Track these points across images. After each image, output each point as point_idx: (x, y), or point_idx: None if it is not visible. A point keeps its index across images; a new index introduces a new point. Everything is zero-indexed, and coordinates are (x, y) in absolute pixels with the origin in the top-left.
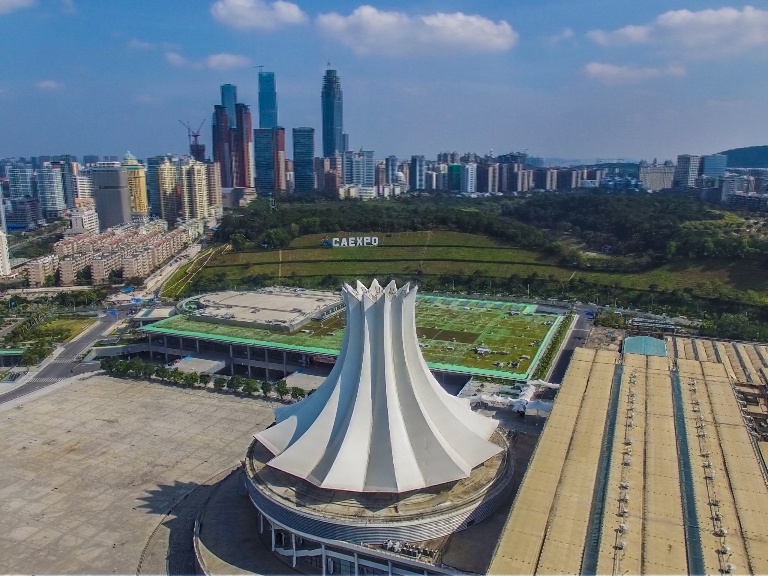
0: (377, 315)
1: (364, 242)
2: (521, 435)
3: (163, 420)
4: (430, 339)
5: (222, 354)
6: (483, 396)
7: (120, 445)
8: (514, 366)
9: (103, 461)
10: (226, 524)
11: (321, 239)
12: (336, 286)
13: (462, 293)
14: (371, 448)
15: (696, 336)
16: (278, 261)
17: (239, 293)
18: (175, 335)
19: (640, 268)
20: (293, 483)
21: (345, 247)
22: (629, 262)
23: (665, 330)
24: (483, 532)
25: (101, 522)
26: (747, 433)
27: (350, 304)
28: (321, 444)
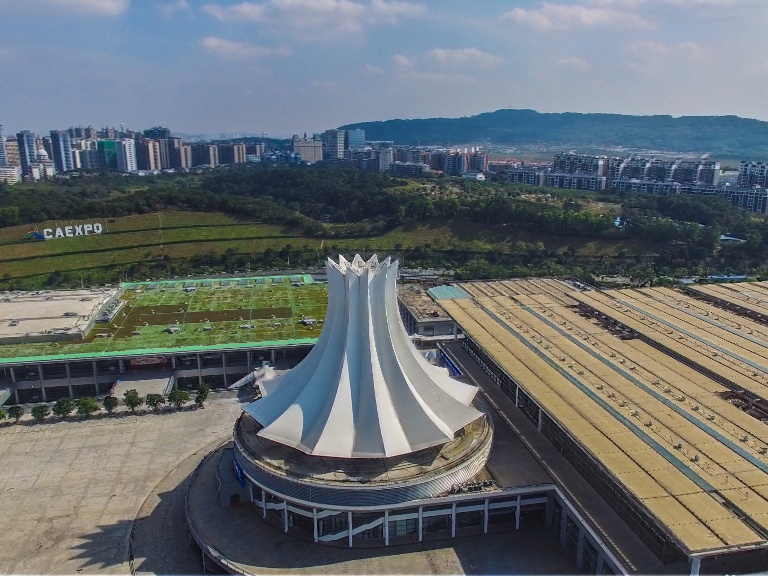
0: (376, 287)
1: (84, 230)
2: None
3: None
4: (248, 320)
5: None
6: None
7: None
8: None
9: None
10: (241, 538)
11: (28, 231)
12: (69, 284)
13: None
14: (397, 412)
15: (471, 280)
16: None
17: None
18: None
19: (379, 231)
20: (335, 466)
21: (61, 238)
22: (369, 227)
23: None
24: (503, 456)
25: None
26: (614, 336)
27: (350, 280)
28: (347, 422)
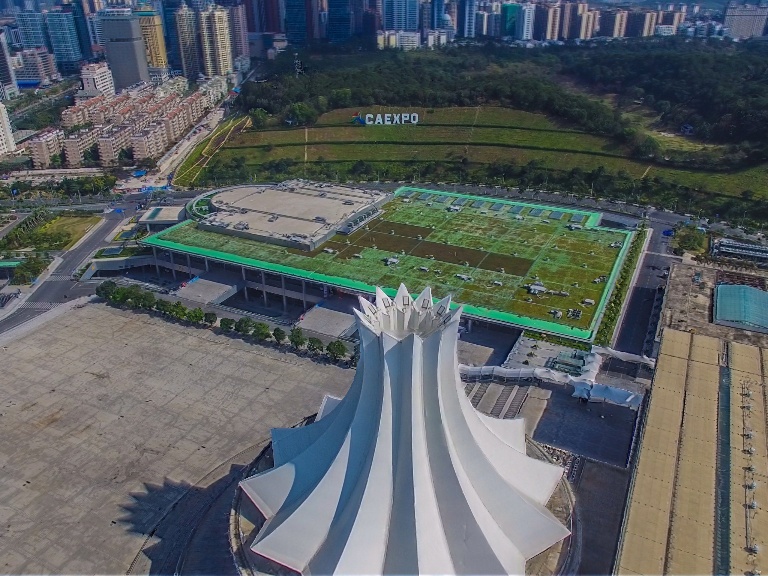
0: (402, 357)
1: (402, 119)
2: (588, 464)
3: (159, 377)
4: (474, 267)
5: (234, 274)
6: (537, 370)
7: (107, 415)
8: (575, 317)
9: (86, 440)
10: None
11: (352, 115)
12: (368, 175)
13: (513, 188)
14: (389, 537)
15: None
16: (304, 142)
17: (256, 190)
18: (180, 252)
19: (731, 167)
20: (286, 570)
21: (380, 125)
22: (718, 158)
23: (761, 260)
24: None
25: (73, 543)
26: None
27: (364, 338)
28: (323, 520)
